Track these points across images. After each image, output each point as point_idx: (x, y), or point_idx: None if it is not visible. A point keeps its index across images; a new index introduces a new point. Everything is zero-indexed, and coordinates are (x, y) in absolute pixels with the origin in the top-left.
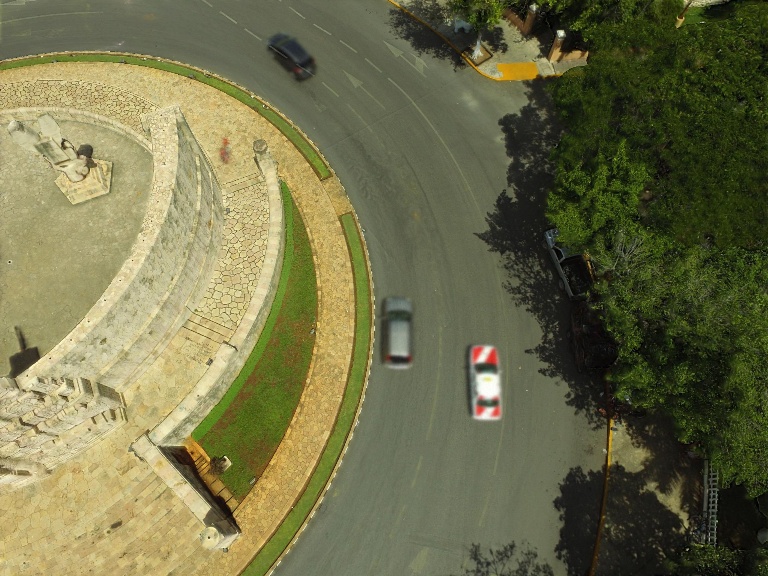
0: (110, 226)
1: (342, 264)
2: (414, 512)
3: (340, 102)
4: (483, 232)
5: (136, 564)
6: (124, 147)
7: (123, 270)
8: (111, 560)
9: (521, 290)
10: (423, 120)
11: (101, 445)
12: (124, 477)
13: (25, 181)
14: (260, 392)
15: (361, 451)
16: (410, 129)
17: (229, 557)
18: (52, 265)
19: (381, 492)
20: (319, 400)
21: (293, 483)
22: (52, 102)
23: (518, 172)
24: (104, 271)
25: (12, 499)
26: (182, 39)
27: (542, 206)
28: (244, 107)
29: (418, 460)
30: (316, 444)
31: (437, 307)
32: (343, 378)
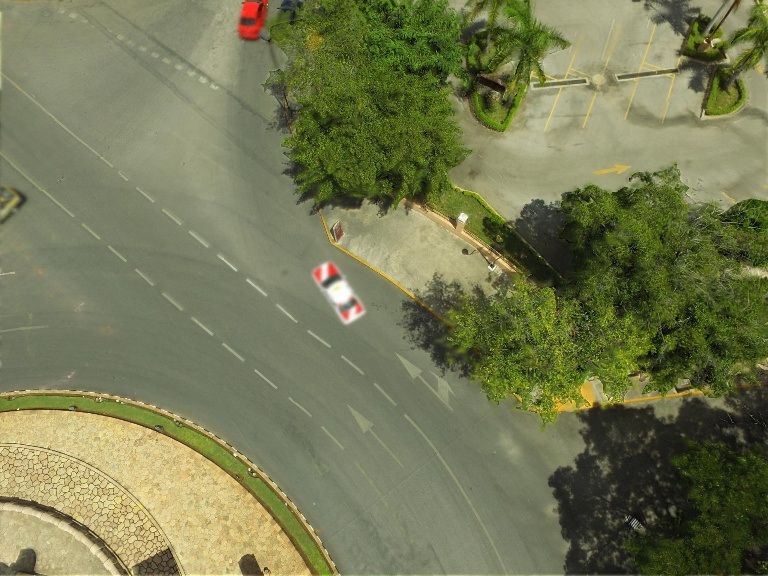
0: None
1: None
2: None
3: (345, 458)
4: None
5: None
6: (75, 551)
7: None
8: None
9: None
10: (452, 483)
11: None
12: None
13: None
14: None
15: None
16: (436, 499)
17: None
18: None
19: None
20: None
21: None
22: None
23: (579, 566)
24: None
25: None
26: (146, 365)
27: None
28: (225, 477)
29: None
30: None
31: None
32: None
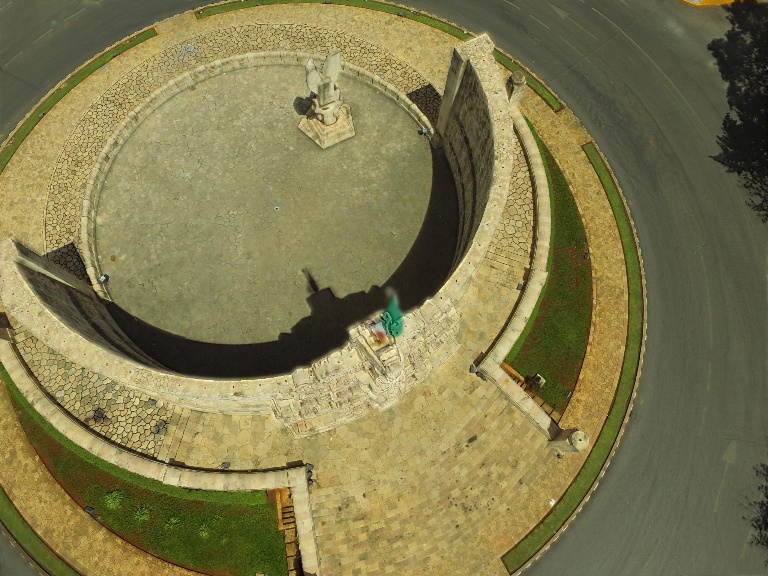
0: (364, 168)
1: (597, 192)
2: (715, 412)
3: (552, 34)
4: (717, 154)
5: (492, 473)
6: (355, 89)
7: (493, 196)
8: (473, 471)
9: (764, 207)
10: (636, 48)
11: (443, 369)
12: (473, 396)
13: (267, 128)
14: (553, 315)
15: (655, 362)
16: (626, 58)
17: (564, 462)
18: (319, 209)
19: (682, 396)
20: (609, 319)
21: (604, 394)
22: (271, 47)
23: (737, 95)
24: (372, 212)
25: (376, 423)
26: None
27: (766, 127)
28: None
29: (708, 366)
30: (616, 358)
31: (692, 227)
32: (625, 297)
